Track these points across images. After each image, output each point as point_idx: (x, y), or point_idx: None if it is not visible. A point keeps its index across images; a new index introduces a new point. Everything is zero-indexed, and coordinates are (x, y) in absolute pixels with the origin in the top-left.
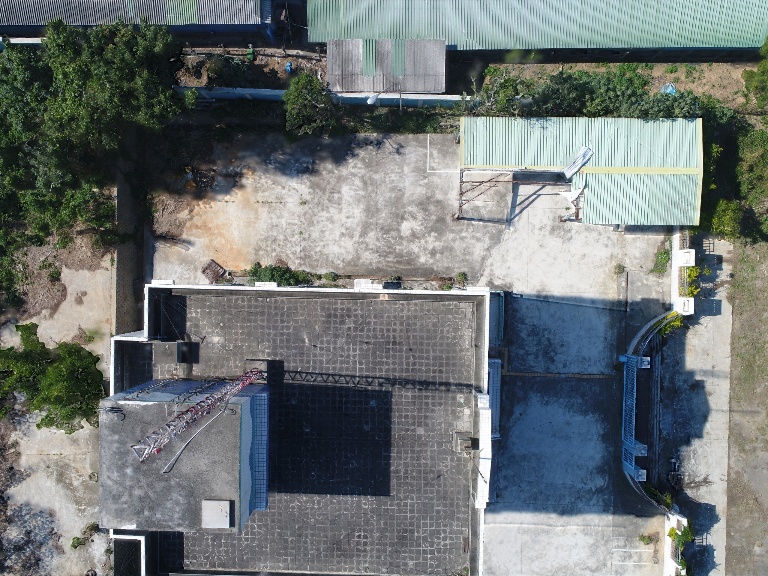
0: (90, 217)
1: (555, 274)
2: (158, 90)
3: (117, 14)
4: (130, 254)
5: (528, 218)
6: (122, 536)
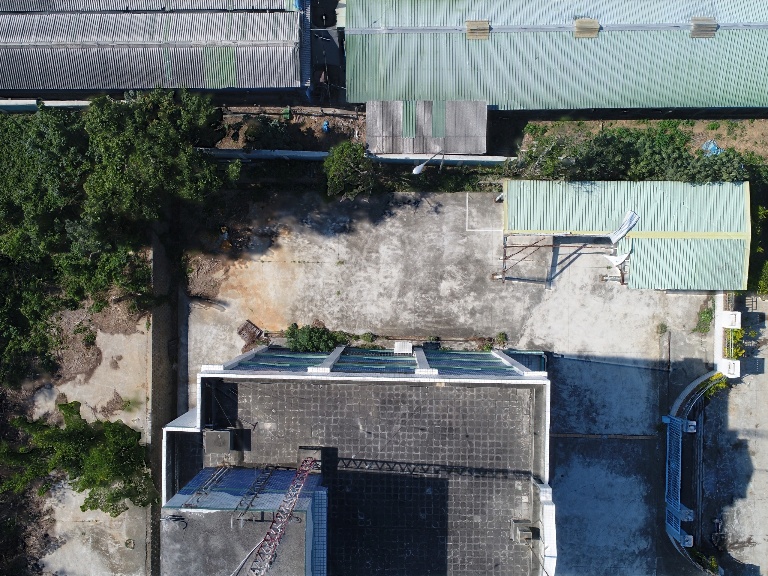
0: (126, 282)
1: (596, 334)
2: (203, 164)
3: (154, 78)
4: (165, 315)
5: (569, 277)
6: None
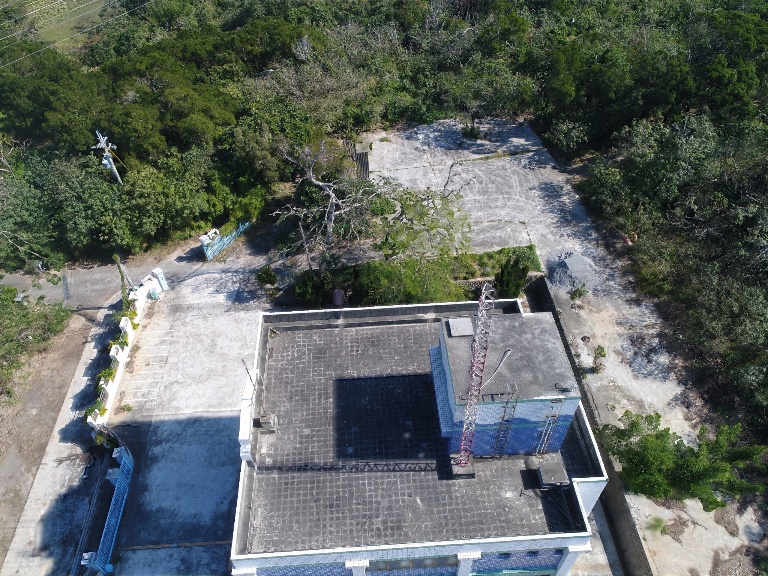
0: None
1: None
2: None
3: None
4: None
5: None
6: None
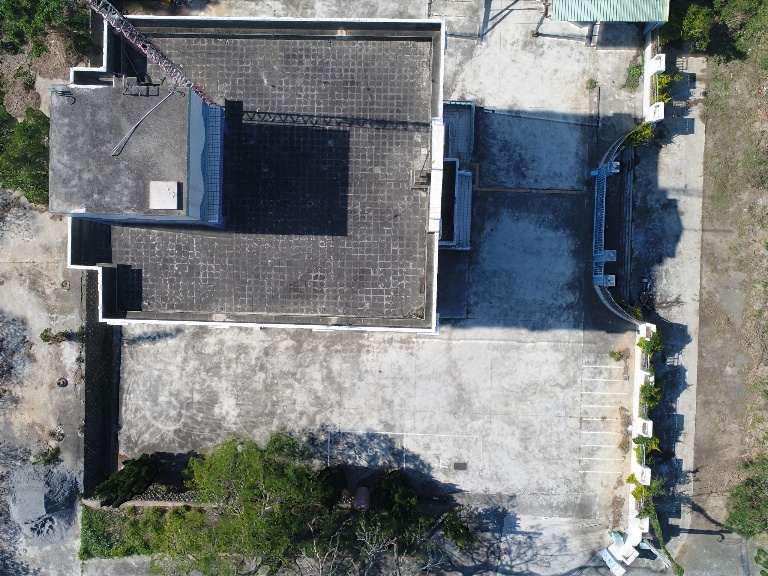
0: (63, 21)
1: (527, 89)
2: None
3: None
4: None
5: (500, 33)
6: (80, 266)
